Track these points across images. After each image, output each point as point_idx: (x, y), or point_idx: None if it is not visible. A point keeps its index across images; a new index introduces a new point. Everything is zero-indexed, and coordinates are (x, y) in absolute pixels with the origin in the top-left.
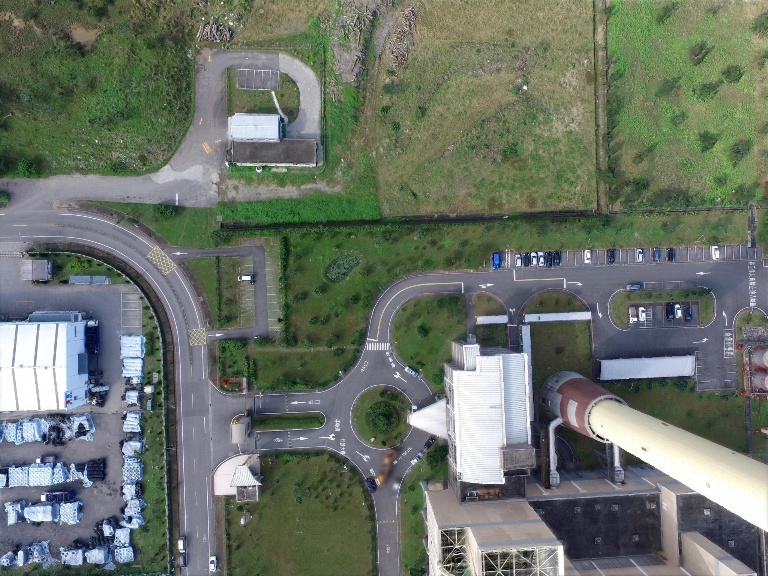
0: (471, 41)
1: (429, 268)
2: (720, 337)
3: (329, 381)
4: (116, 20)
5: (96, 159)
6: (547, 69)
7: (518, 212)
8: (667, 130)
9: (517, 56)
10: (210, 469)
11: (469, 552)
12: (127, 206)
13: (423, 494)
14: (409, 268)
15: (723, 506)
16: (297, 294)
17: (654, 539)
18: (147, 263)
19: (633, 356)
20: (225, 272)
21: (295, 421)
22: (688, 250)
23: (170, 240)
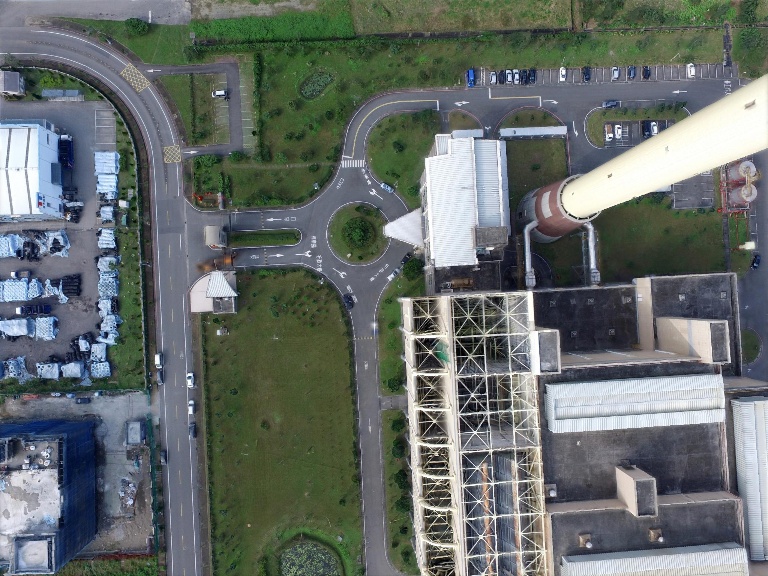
0: None
1: (404, 85)
2: None
3: (305, 197)
4: None
5: None
6: None
7: (493, 31)
8: None
9: None
10: (186, 286)
11: (441, 323)
12: (100, 23)
13: (401, 310)
14: (384, 85)
15: (681, 165)
16: (271, 110)
17: (630, 334)
18: (121, 80)
19: None
20: (199, 89)
21: (271, 236)
22: (664, 69)
23: (143, 57)
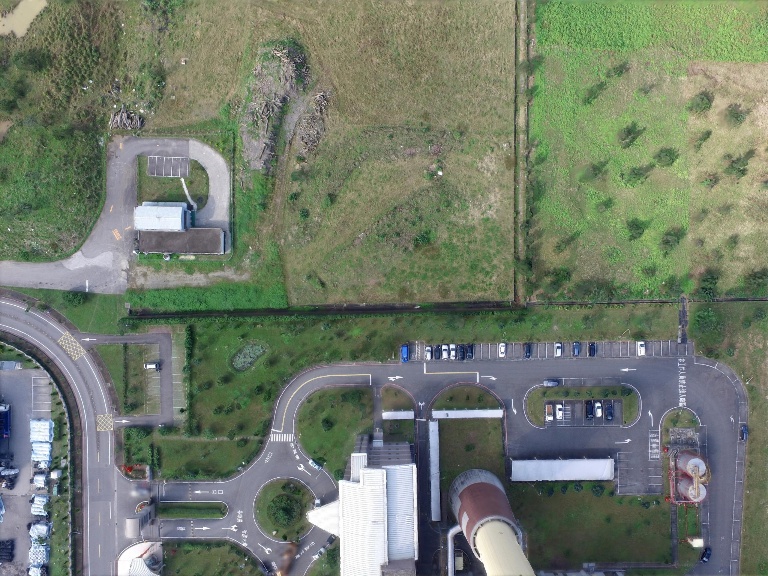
0: (384, 125)
1: (336, 359)
2: (645, 438)
3: (232, 472)
4: (27, 112)
5: (10, 246)
6: (464, 154)
7: (430, 302)
8: (592, 217)
9: (432, 141)
10: (114, 554)
11: None
12: (39, 292)
13: None
14: (315, 359)
15: None
16: (202, 383)
17: None
18: (58, 348)
19: (549, 456)
20: (132, 359)
21: (197, 511)
22: (612, 345)
23: (80, 326)
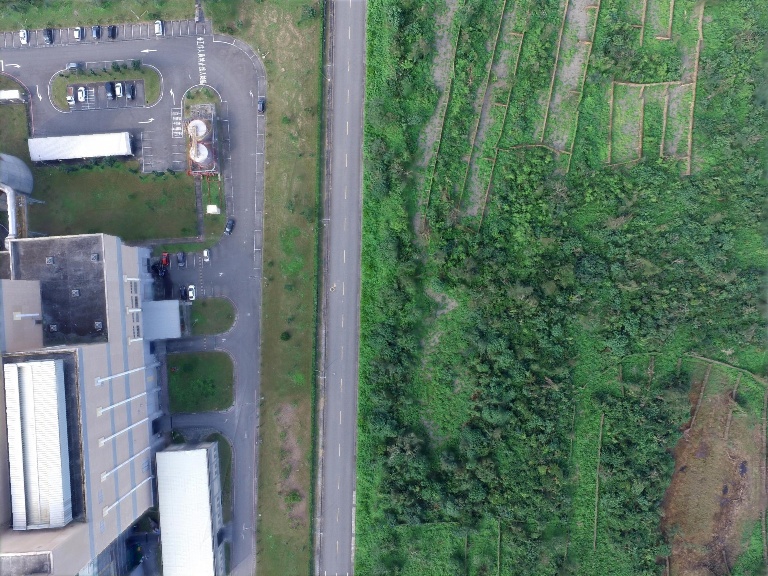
0: None
1: None
2: (167, 117)
3: None
4: None
5: None
6: None
7: None
8: None
9: None
10: None
11: None
12: None
13: None
14: None
15: None
16: None
17: None
18: None
19: None
20: None
21: None
22: (132, 27)
23: None
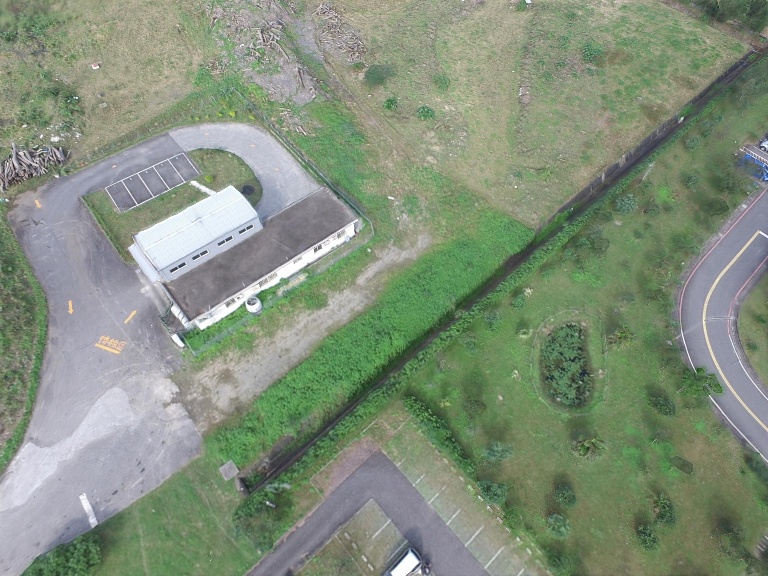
0: None
1: None
2: None
3: None
4: None
5: None
6: None
7: (687, 104)
8: None
9: None
10: None
11: None
12: None
13: None
14: (668, 270)
15: None
16: (547, 500)
17: None
18: None
19: None
20: None
21: None
22: None
23: None
